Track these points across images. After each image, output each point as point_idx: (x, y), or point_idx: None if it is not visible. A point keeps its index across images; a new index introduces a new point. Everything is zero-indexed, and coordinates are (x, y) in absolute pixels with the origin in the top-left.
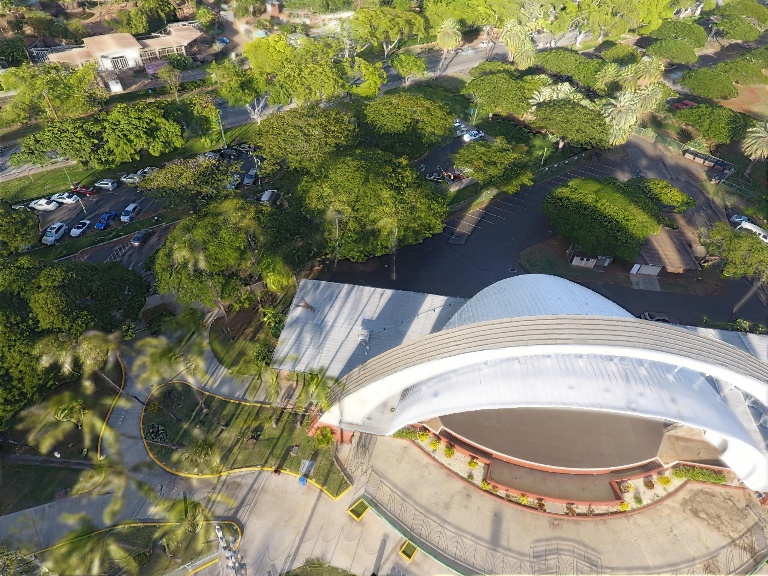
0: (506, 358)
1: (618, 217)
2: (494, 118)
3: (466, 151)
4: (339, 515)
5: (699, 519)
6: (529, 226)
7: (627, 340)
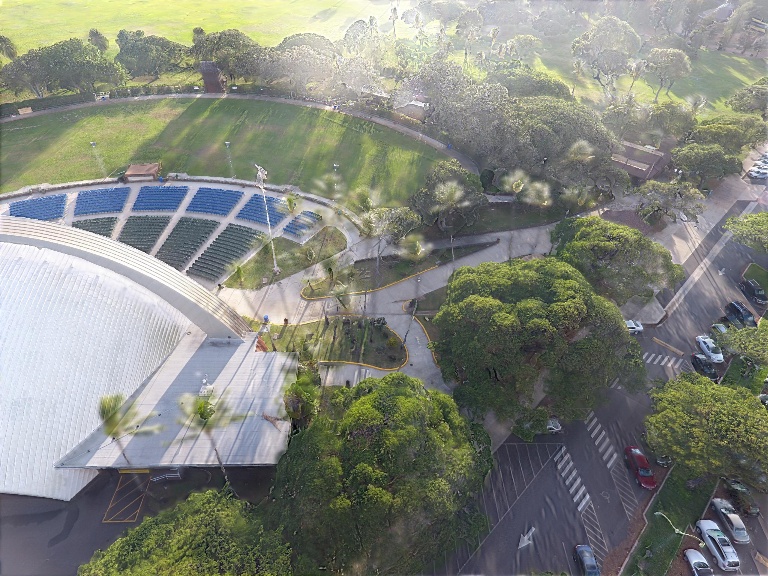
0: (79, 273)
1: None
2: None
3: None
4: (241, 309)
5: None
6: None
7: None
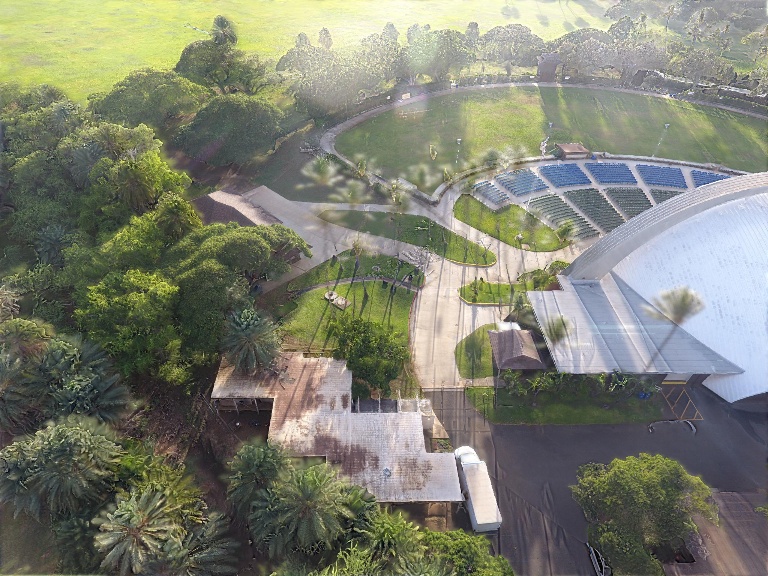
0: None
1: None
2: None
3: None
4: None
5: None
6: None
7: None
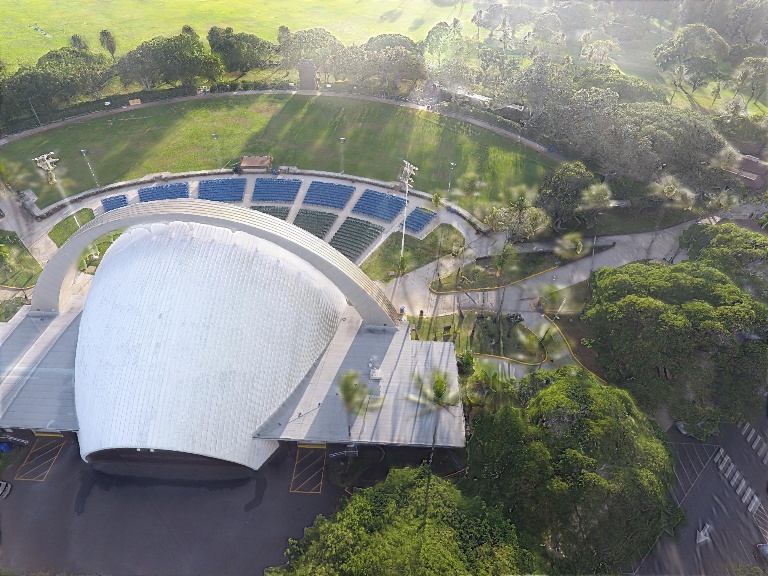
0: (264, 256)
1: None
2: None
3: None
4: None
5: None
6: None
7: (194, 202)
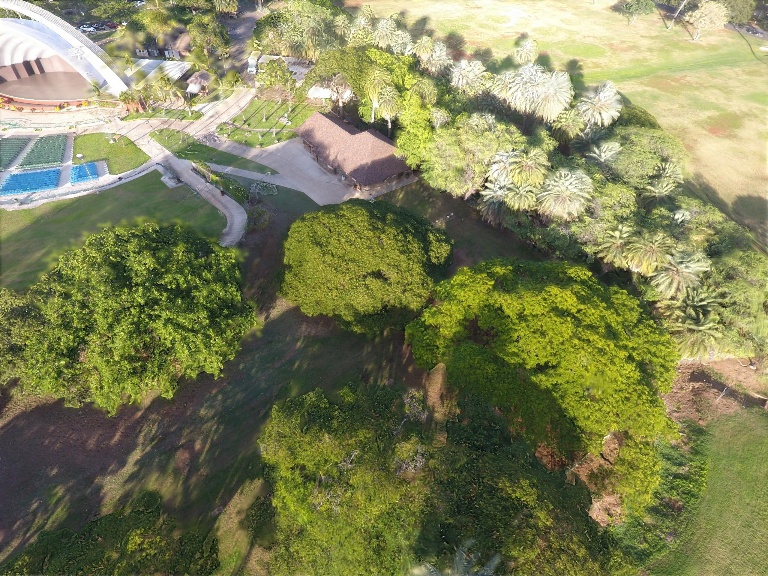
0: None
1: (145, 22)
2: (177, 6)
3: (102, 4)
4: None
5: (91, 114)
6: (134, 44)
7: None
